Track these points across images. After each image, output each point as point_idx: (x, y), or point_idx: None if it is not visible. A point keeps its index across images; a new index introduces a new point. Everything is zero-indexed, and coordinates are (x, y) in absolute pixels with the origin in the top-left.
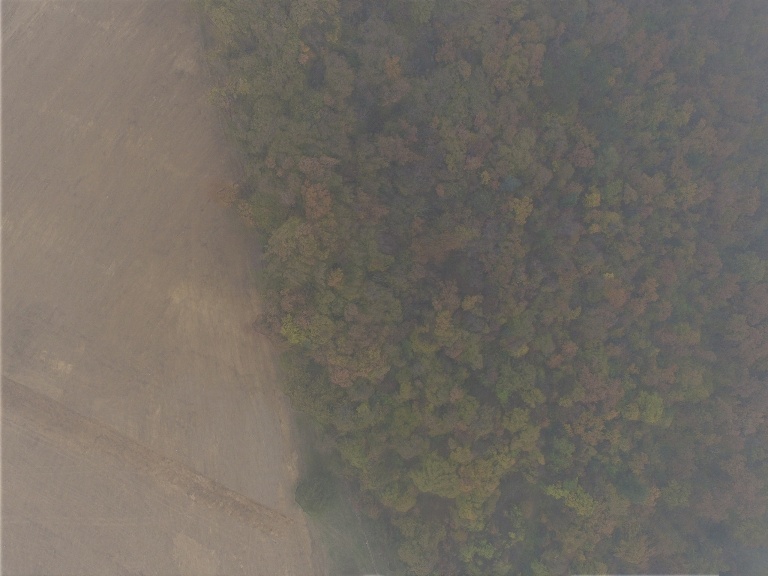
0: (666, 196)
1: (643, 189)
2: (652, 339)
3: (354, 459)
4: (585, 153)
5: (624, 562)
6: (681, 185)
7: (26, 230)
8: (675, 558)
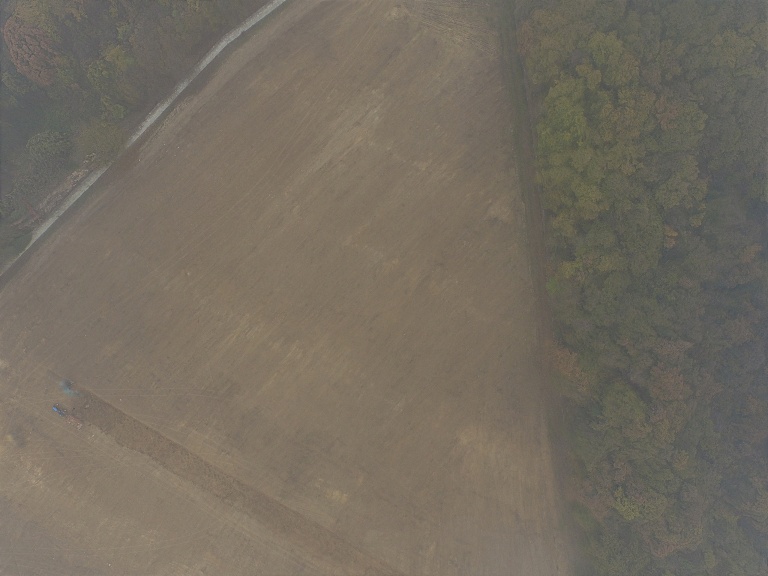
0: None
1: None
2: None
3: None
4: None
5: None
6: None
7: (315, 359)
8: None
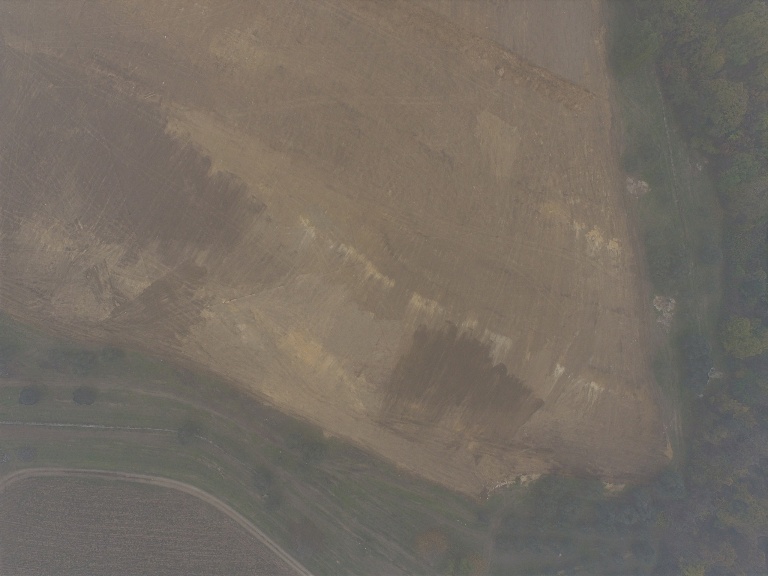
0: None
1: None
2: None
3: (684, 1)
4: None
5: None
6: None
7: None
8: None
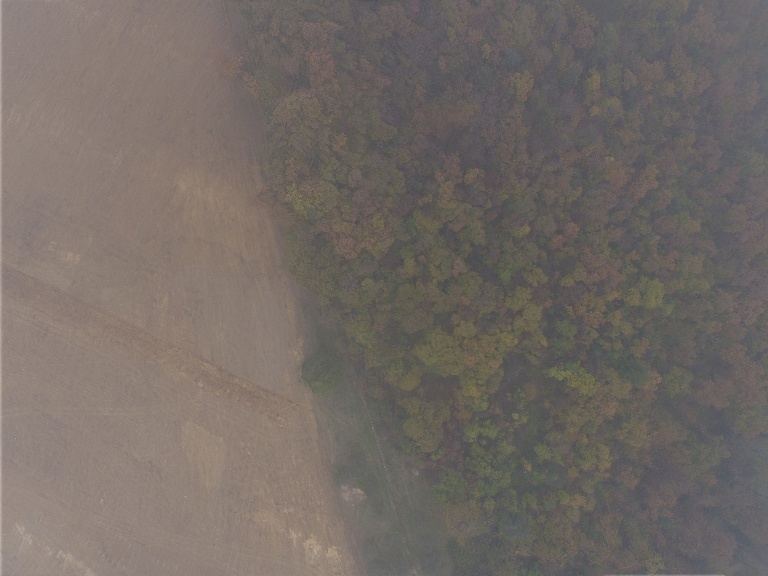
0: (666, 84)
1: (643, 75)
2: (653, 225)
3: (359, 334)
4: (585, 32)
5: (626, 446)
6: (681, 74)
7: (34, 121)
8: (677, 445)
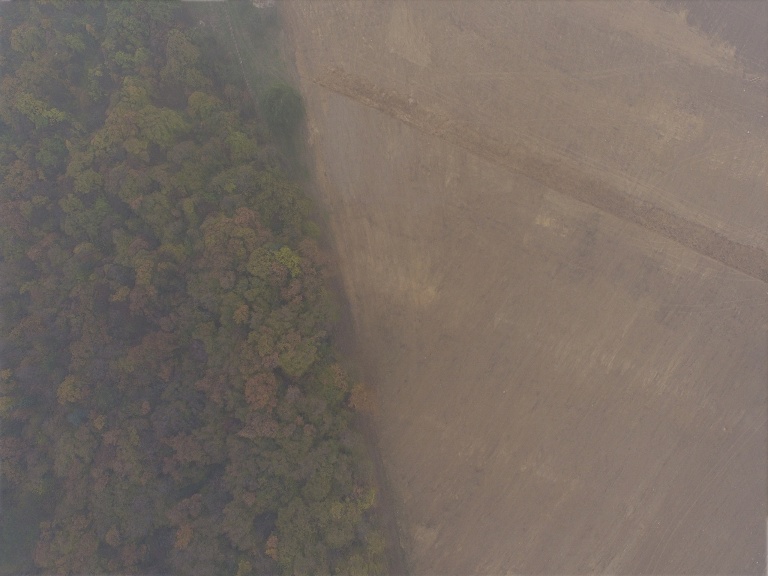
0: None
1: None
2: None
3: (240, 139)
4: (7, 452)
5: None
6: None
7: (587, 356)
8: None
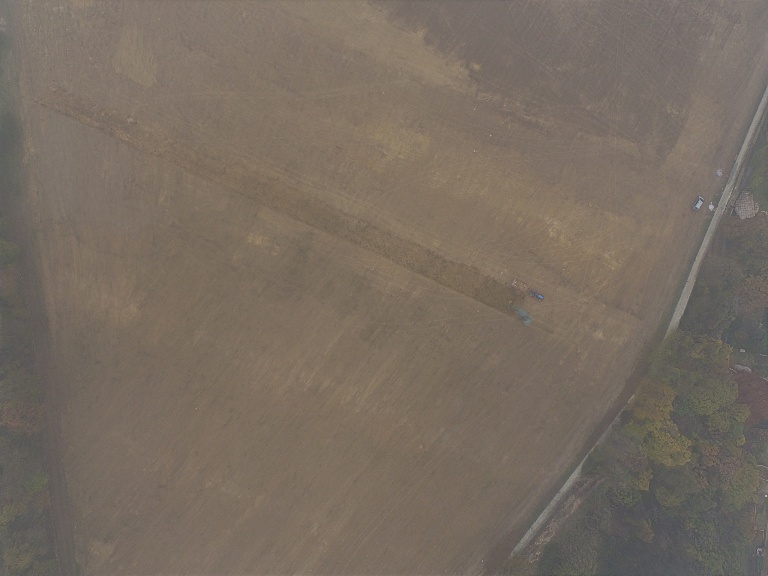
0: None
1: None
2: None
3: None
4: None
5: None
6: None
7: (286, 373)
8: None
